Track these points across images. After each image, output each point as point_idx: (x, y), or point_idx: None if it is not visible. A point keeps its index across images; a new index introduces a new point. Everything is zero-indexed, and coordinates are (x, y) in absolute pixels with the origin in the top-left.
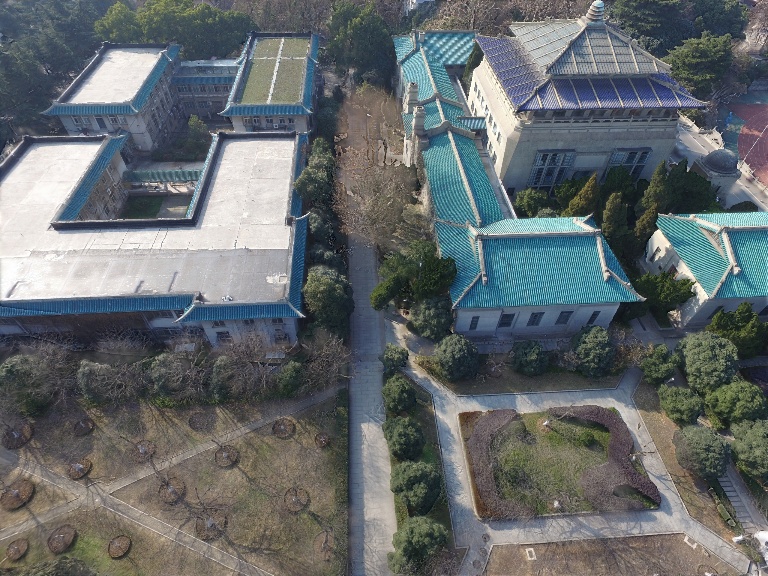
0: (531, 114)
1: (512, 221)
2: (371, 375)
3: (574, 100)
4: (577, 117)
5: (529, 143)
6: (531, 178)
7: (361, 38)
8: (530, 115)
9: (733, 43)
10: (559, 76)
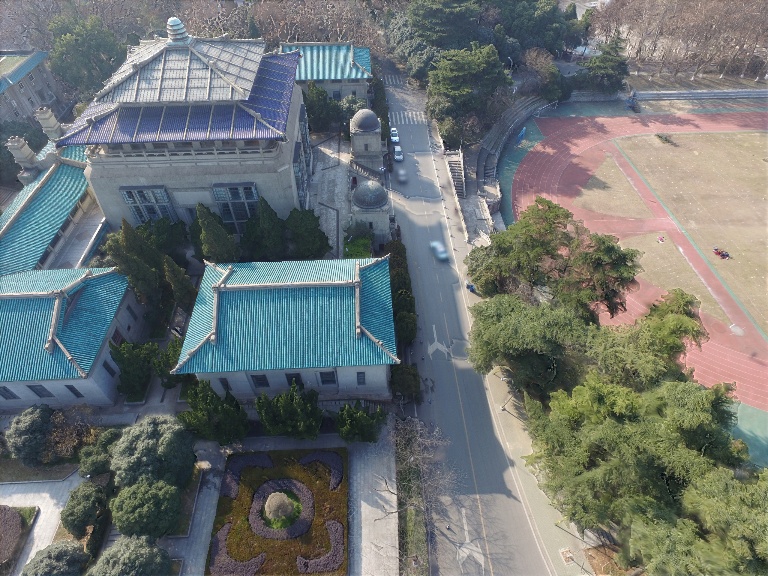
0: (104, 147)
1: (28, 274)
2: None
3: (131, 132)
4: (162, 149)
5: (104, 179)
6: (133, 216)
7: (83, 55)
8: (104, 148)
9: (532, 52)
10: (131, 104)
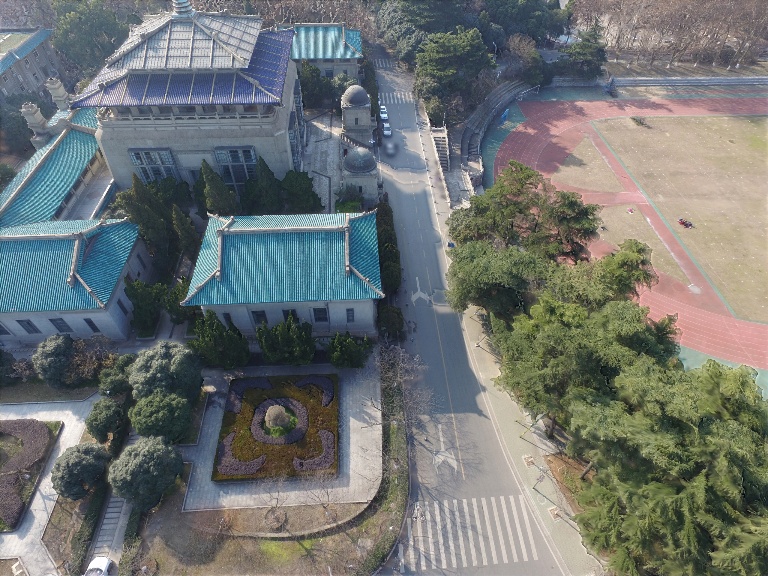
0: (114, 111)
1: (46, 223)
2: None
3: (140, 96)
4: (168, 114)
5: (114, 141)
6: (140, 178)
7: (86, 33)
8: (114, 112)
9: (515, 38)
10: (139, 71)
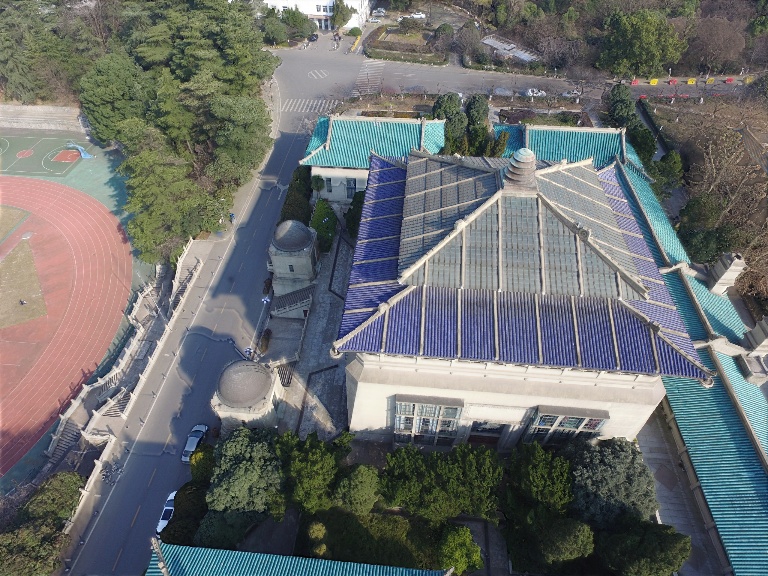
0: None
1: None
2: (656, 159)
3: None
4: None
5: None
6: None
7: None
8: None
9: None
10: None
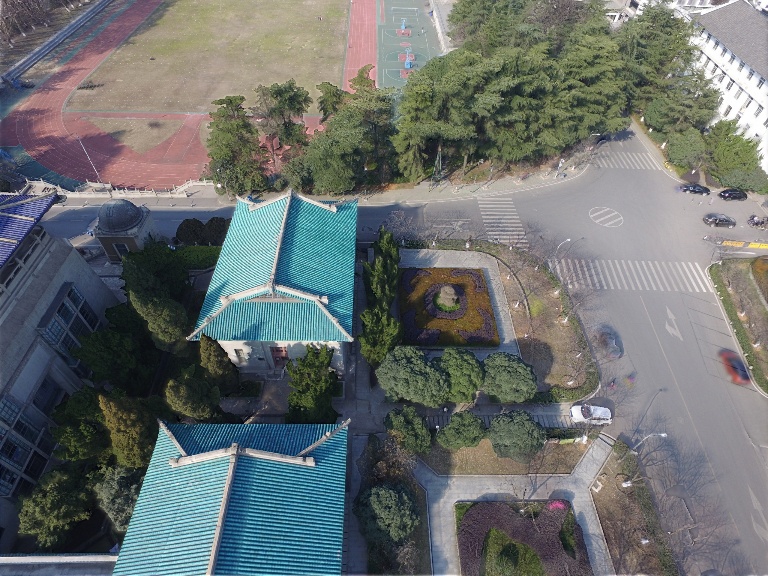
0: None
1: None
2: None
3: None
4: None
5: None
6: None
7: None
8: None
9: None
10: None
